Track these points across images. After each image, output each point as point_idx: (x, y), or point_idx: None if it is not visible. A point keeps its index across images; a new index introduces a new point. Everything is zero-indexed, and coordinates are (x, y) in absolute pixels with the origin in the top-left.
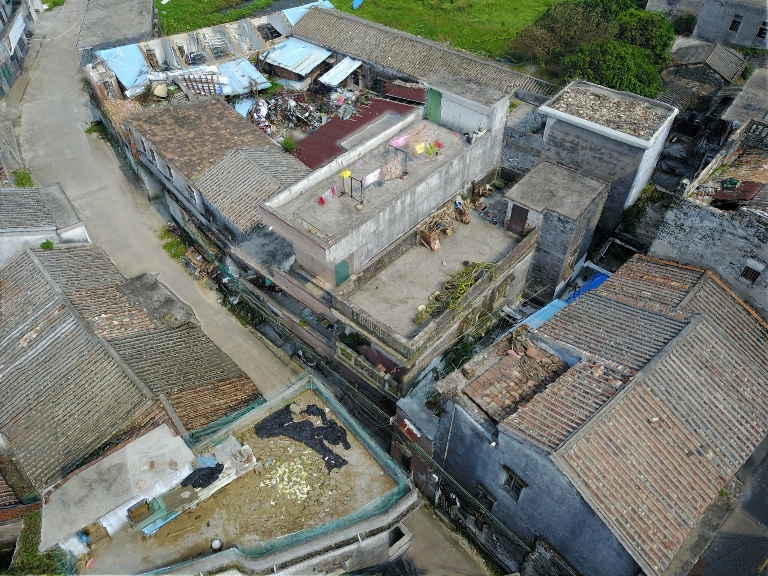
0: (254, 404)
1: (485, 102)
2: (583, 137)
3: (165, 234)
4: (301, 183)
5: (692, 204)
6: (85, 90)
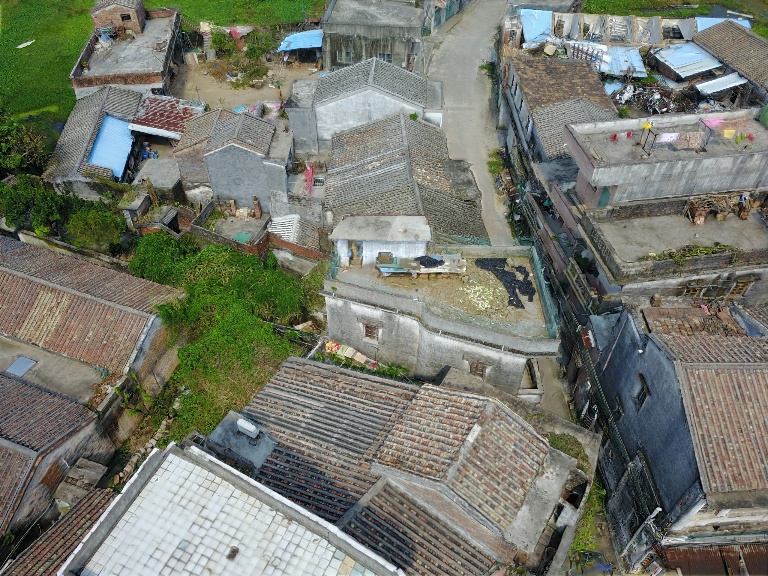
0: (484, 239)
1: None
2: None
3: (494, 154)
4: (608, 123)
5: None
6: (495, 37)
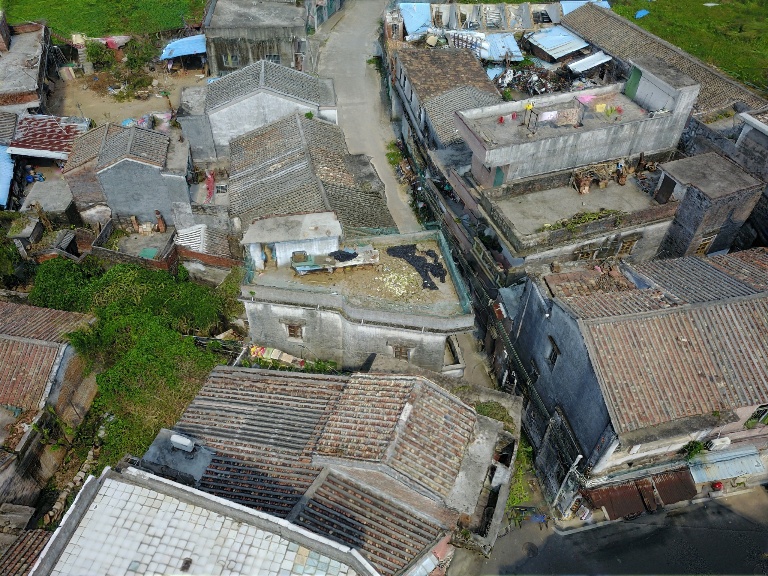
0: (393, 228)
1: (674, 84)
2: None
3: (391, 146)
4: (493, 107)
5: None
6: (379, 32)
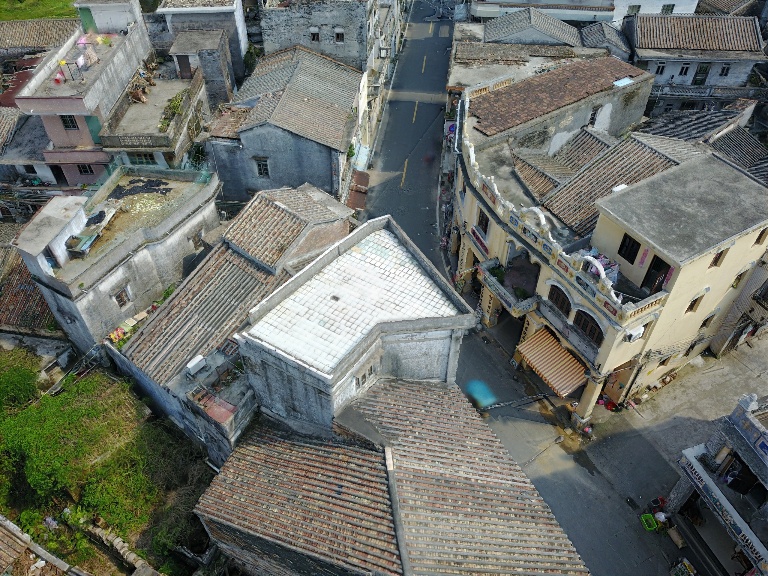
0: None
1: (124, 1)
2: (194, 20)
3: None
4: (32, 82)
5: (270, 10)
6: None
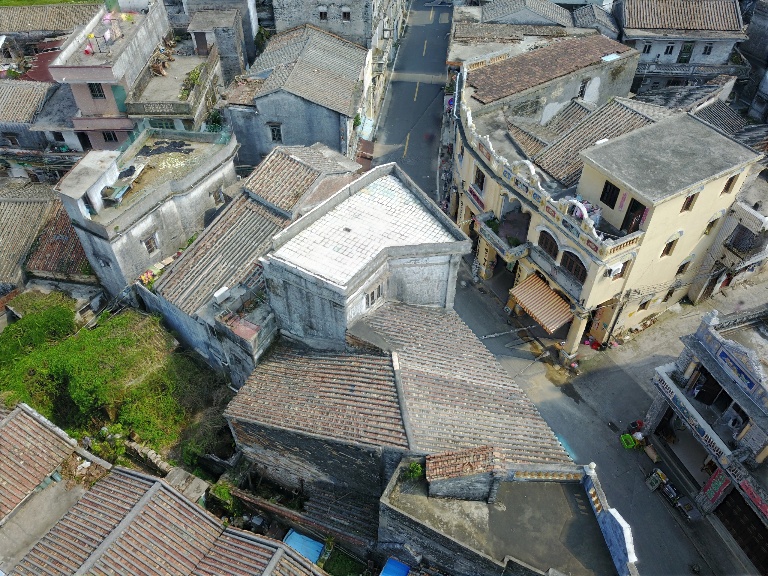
0: None
1: None
2: (209, 2)
3: None
4: (63, 53)
5: None
6: None
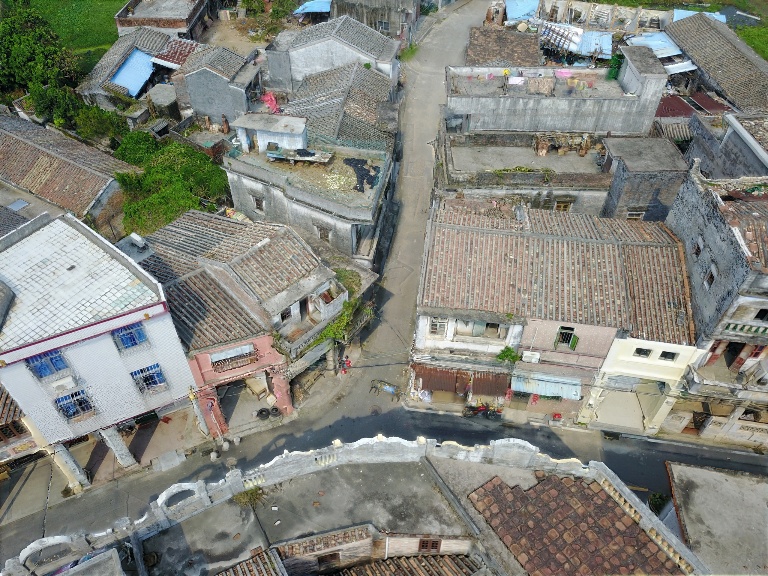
0: (350, 142)
1: (641, 70)
2: (744, 152)
3: None
4: (482, 69)
5: (692, 180)
6: None
